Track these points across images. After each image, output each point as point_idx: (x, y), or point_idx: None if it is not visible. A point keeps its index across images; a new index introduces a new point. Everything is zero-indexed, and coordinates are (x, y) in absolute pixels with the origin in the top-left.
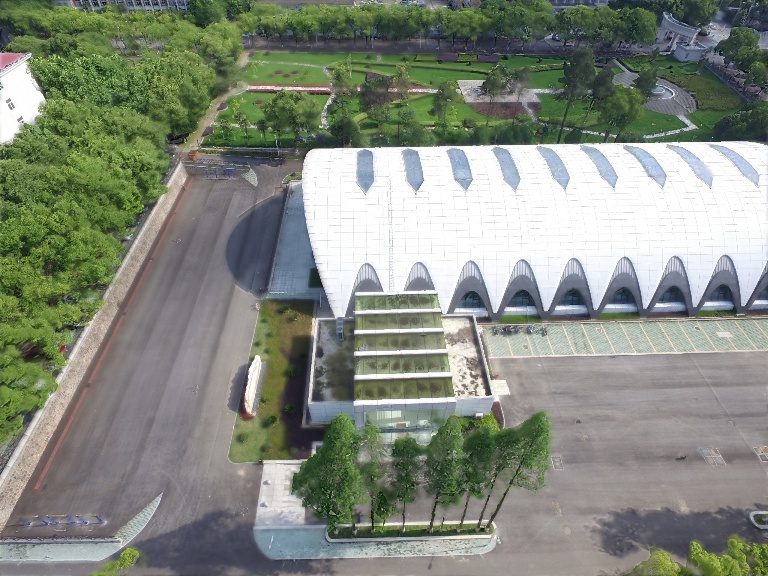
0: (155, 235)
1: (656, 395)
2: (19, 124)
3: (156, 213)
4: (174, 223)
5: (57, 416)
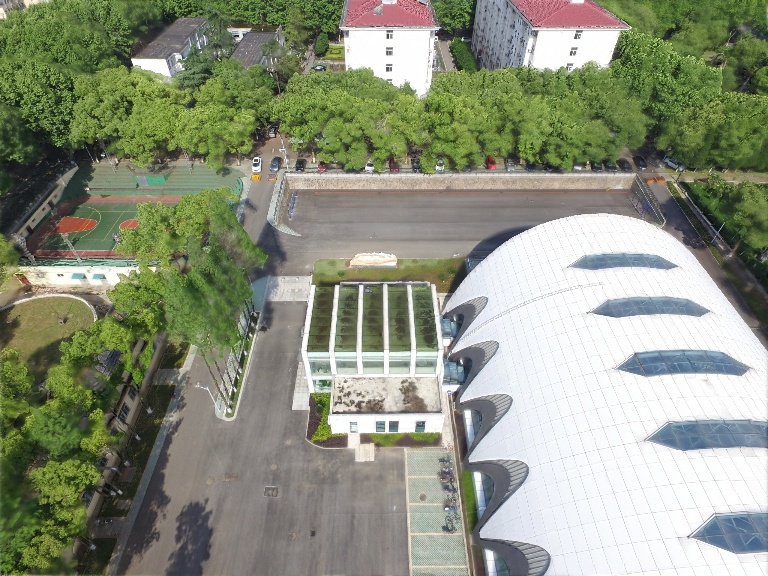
0: (530, 188)
1: None
2: (560, 65)
3: (552, 178)
4: (552, 194)
5: (356, 186)
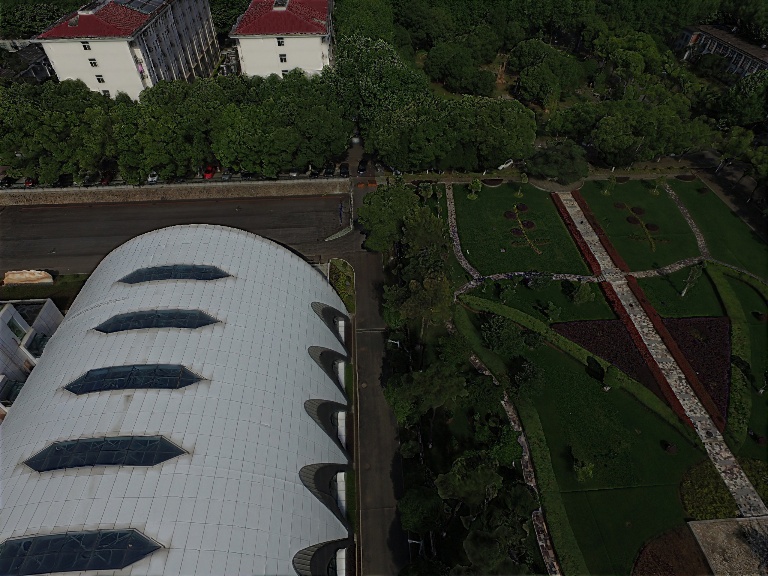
0: (248, 195)
1: None
2: (270, 72)
3: (266, 185)
4: (266, 202)
5: (67, 200)
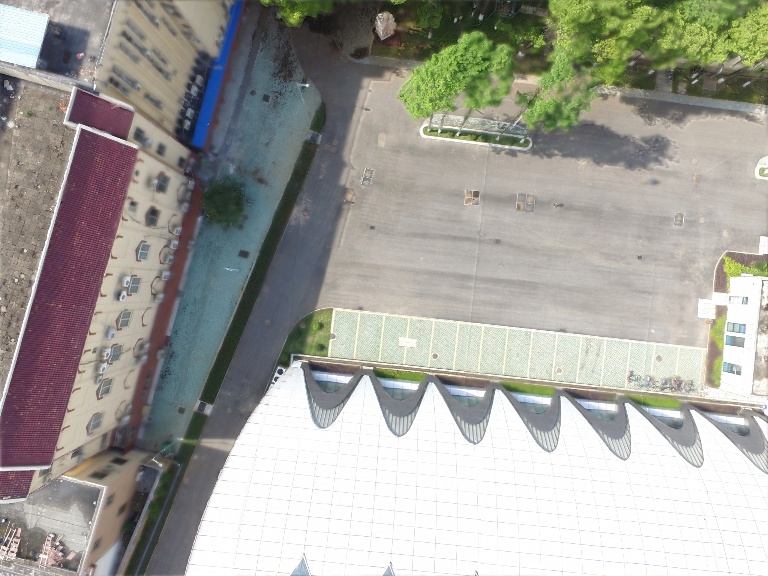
0: None
1: (542, 275)
2: None
3: None
4: None
5: None
